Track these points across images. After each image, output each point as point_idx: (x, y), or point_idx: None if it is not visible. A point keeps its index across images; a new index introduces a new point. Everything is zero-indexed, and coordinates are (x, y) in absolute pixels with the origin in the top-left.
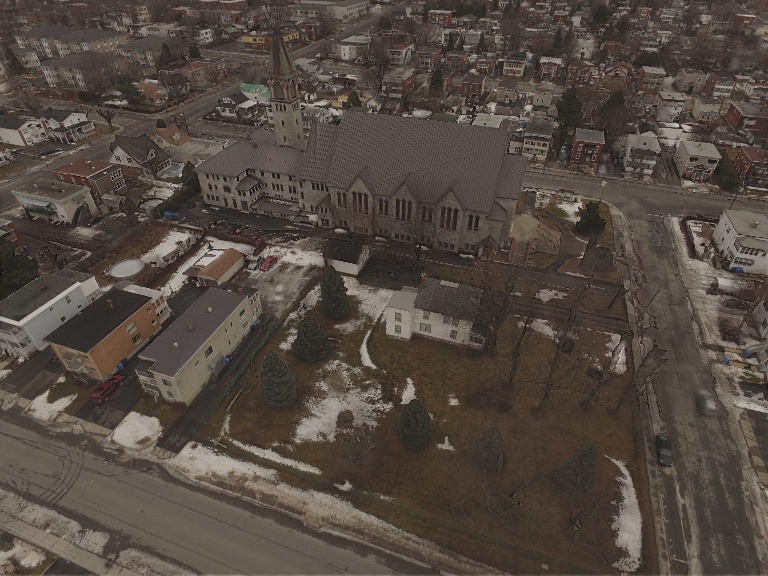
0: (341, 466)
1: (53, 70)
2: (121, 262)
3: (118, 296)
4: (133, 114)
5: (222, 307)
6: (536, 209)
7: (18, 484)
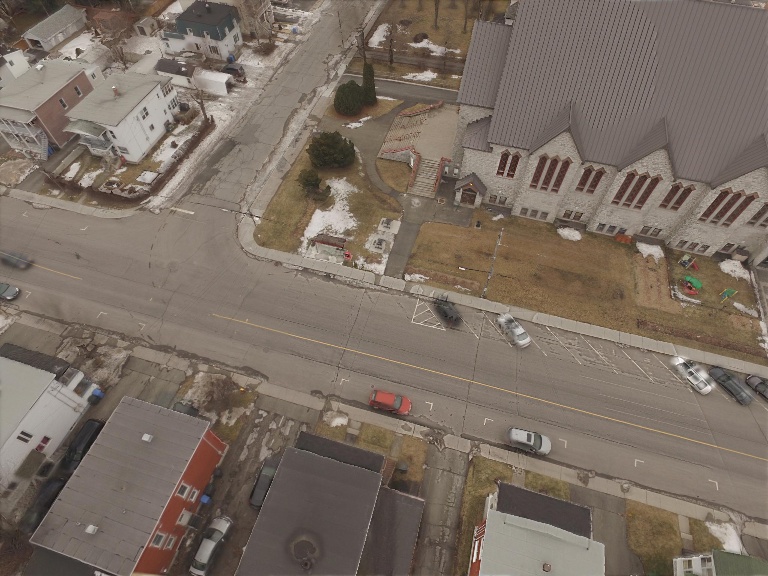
0: None
1: None
2: None
3: None
4: None
5: None
6: (401, 212)
7: None
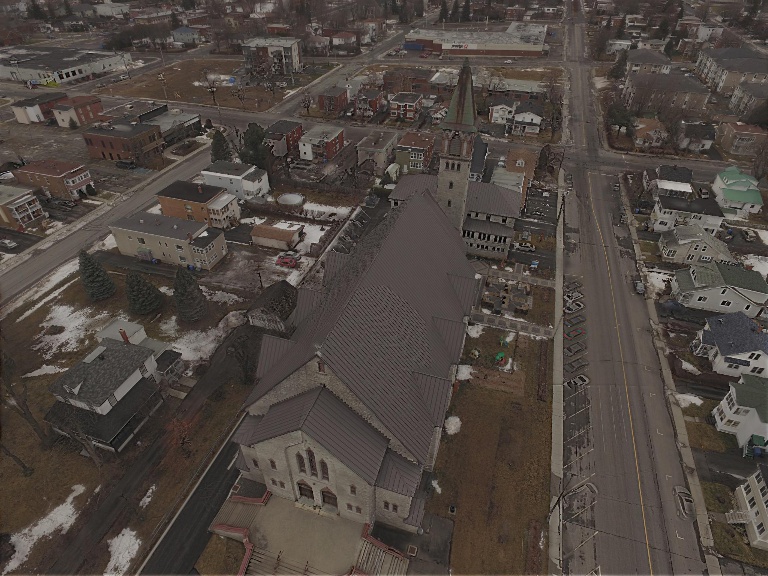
0: (13, 331)
1: (628, 82)
2: (299, 195)
3: (214, 192)
4: (601, 141)
5: (178, 232)
6: None
7: (104, 216)
